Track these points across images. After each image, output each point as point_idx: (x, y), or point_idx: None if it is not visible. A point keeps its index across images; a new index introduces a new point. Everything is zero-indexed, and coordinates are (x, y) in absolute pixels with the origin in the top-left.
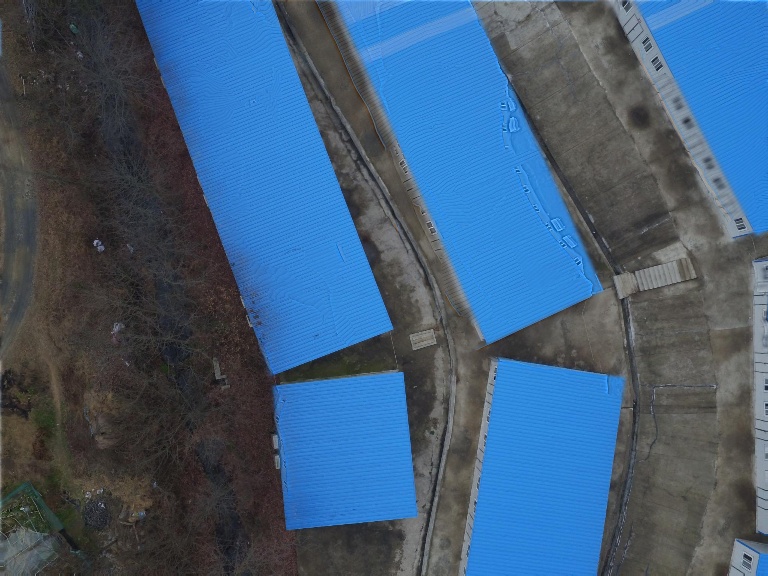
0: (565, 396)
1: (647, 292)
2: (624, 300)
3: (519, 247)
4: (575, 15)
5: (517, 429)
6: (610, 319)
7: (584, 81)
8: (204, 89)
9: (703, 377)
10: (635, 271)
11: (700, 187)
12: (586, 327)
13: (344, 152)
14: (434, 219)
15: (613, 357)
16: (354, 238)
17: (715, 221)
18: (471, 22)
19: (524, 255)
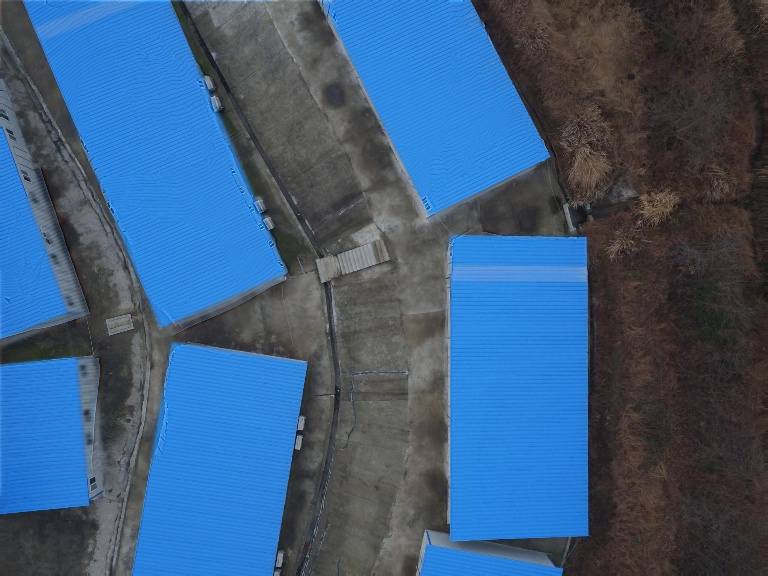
0: (246, 382)
1: (348, 276)
2: (327, 284)
3: (221, 230)
4: None
5: (196, 416)
6: (312, 304)
7: (280, 58)
8: None
9: (397, 363)
10: (337, 254)
11: (395, 166)
12: (286, 312)
13: (44, 133)
14: (111, 199)
15: (314, 343)
16: (53, 221)
17: (409, 201)
18: None
19: (225, 238)
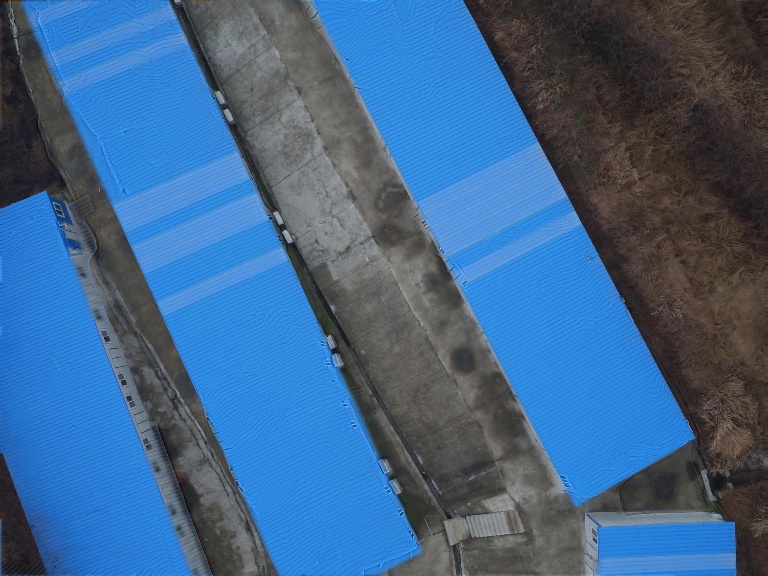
0: None
1: (478, 539)
2: (455, 546)
3: (345, 489)
4: (394, 250)
5: None
6: (441, 566)
7: (405, 320)
8: None
9: None
10: (466, 516)
11: (528, 434)
12: (415, 575)
13: (161, 390)
14: (241, 479)
15: None
16: (172, 481)
17: (544, 471)
18: (280, 265)
19: None
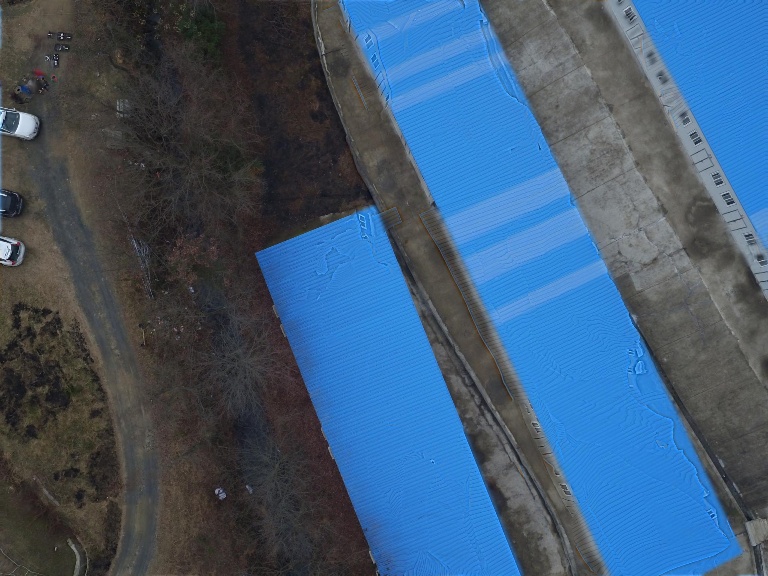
0: None
1: None
2: (756, 546)
3: (647, 492)
4: (705, 262)
5: None
6: (743, 566)
7: (715, 329)
8: (368, 425)
9: None
10: (767, 518)
11: None
12: (718, 575)
13: (467, 397)
14: (569, 482)
15: None
16: (479, 485)
17: None
18: (601, 276)
19: (653, 501)
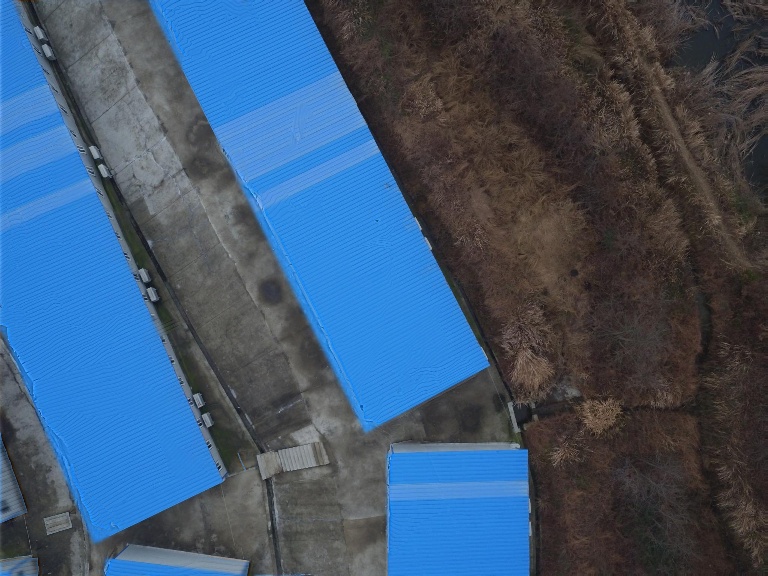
0: None
1: (289, 473)
2: (268, 480)
3: (160, 424)
4: (204, 183)
5: None
6: (253, 501)
7: (215, 252)
8: None
9: (338, 569)
10: (278, 450)
11: (333, 366)
12: (227, 510)
13: None
14: (42, 408)
15: (255, 542)
16: None
17: (349, 403)
18: (88, 196)
19: (163, 433)
